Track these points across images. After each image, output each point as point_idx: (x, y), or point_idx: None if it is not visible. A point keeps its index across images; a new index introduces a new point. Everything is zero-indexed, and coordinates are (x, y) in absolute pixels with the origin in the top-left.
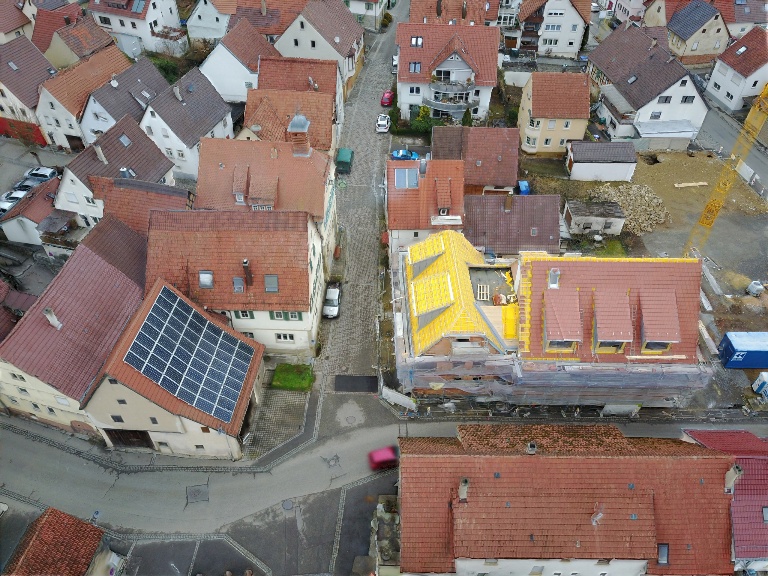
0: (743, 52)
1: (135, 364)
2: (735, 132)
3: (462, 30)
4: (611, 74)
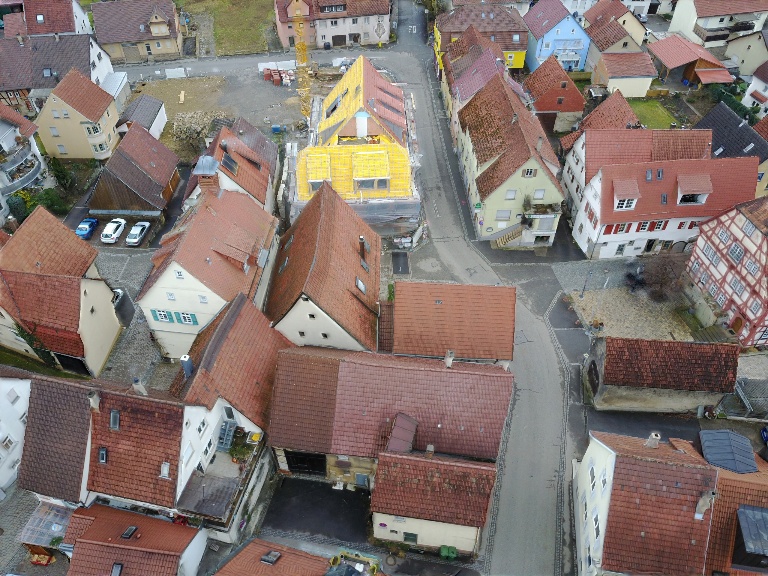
0: (44, 19)
1: None
2: (115, 69)
3: None
4: (16, 85)
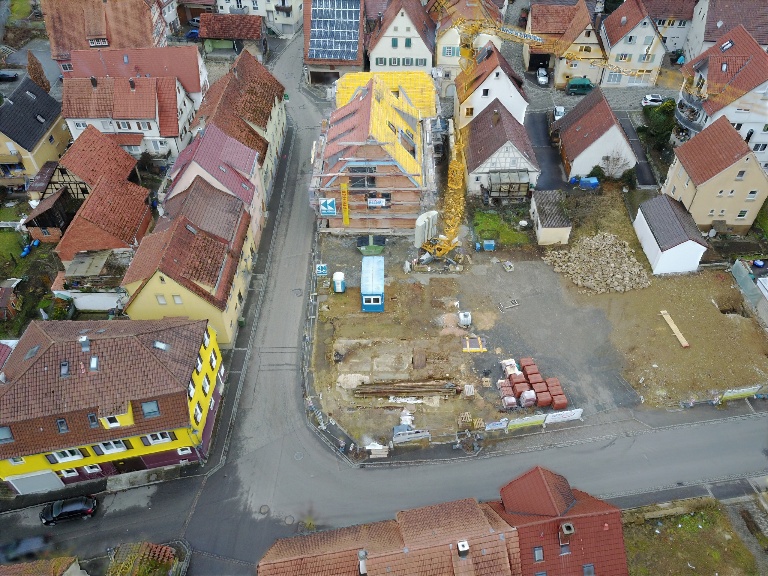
0: None
1: (314, 4)
2: None
3: (759, 55)
4: None
